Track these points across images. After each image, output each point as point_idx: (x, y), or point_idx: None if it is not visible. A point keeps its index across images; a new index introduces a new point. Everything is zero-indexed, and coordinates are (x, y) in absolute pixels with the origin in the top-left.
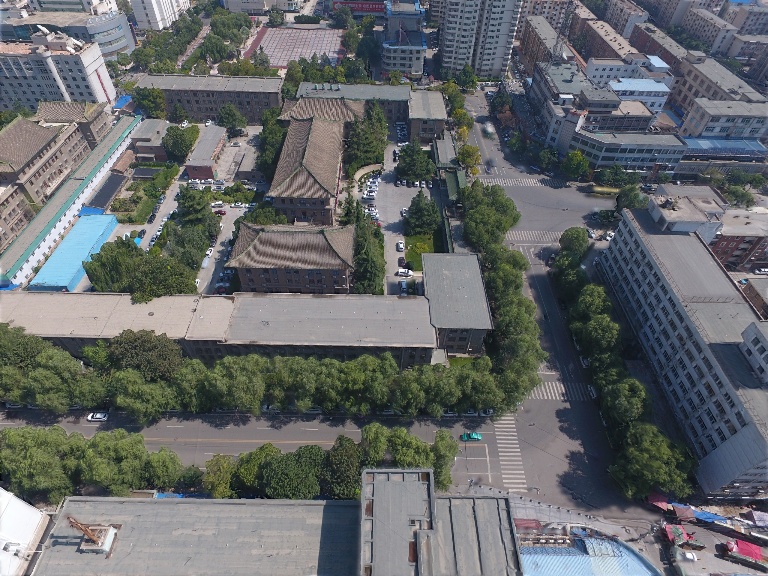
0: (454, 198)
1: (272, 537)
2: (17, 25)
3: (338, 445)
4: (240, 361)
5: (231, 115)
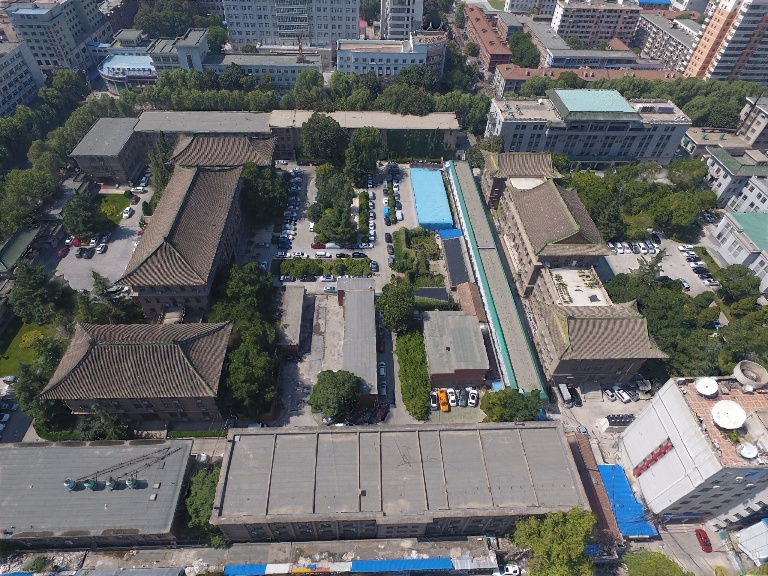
0: None
1: (240, 61)
2: None
3: (212, 78)
4: (258, 94)
5: None
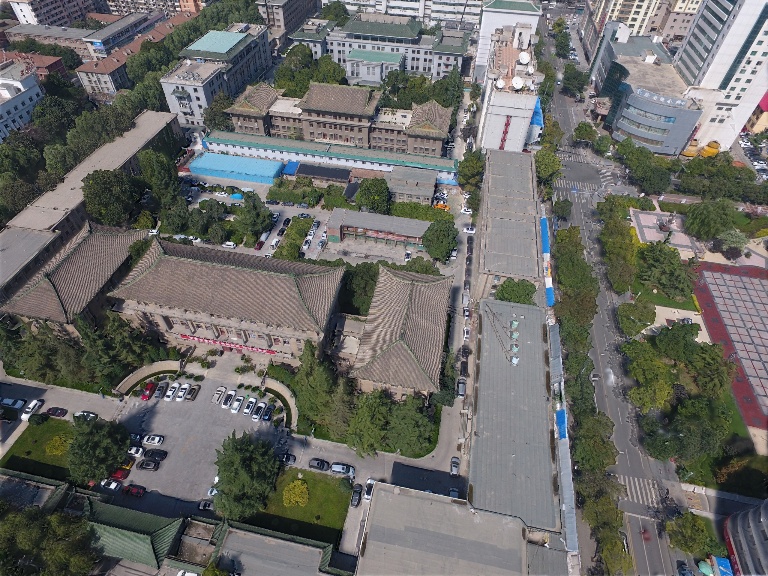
0: (87, 508)
1: None
2: (616, 61)
3: None
4: None
5: None
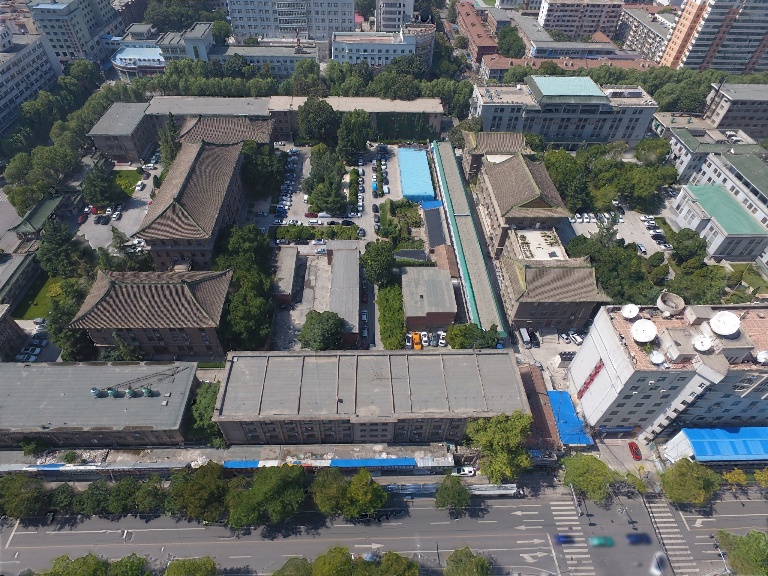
0: None
1: (243, 52)
2: None
3: (216, 67)
4: (258, 81)
5: None
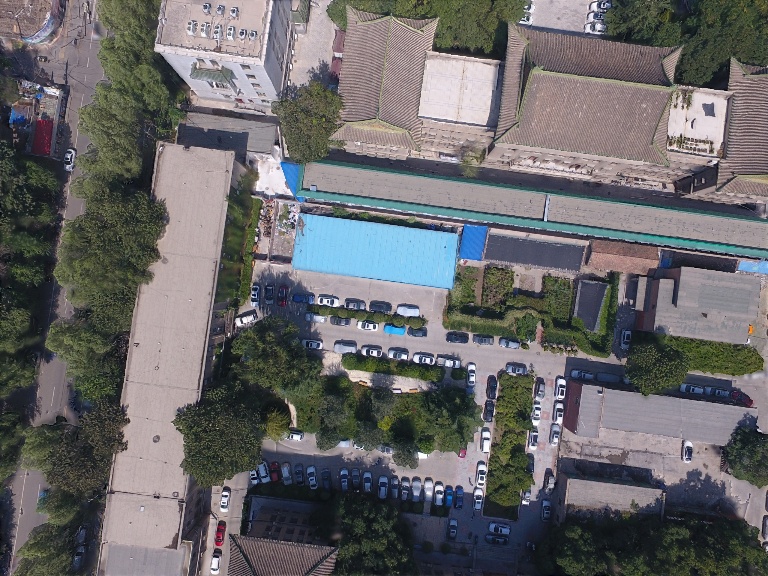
0: None
1: None
2: None
3: None
4: None
5: (760, 467)
